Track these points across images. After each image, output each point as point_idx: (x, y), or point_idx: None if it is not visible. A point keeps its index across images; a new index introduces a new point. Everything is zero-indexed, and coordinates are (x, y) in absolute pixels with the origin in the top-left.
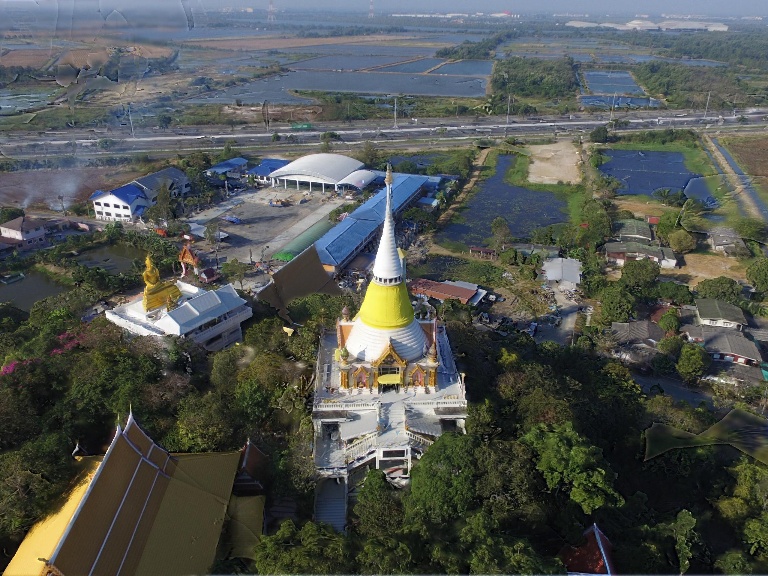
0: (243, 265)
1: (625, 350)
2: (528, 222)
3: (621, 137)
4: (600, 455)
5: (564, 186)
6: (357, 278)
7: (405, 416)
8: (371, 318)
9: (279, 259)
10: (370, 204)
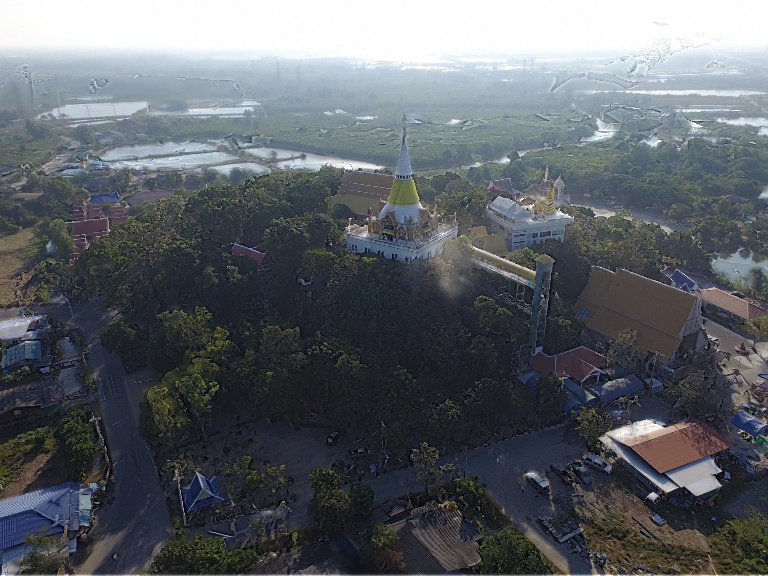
0: (766, 324)
1: (420, 508)
2: None
3: None
4: (274, 237)
5: None
6: None
7: None
8: None
9: None
10: None
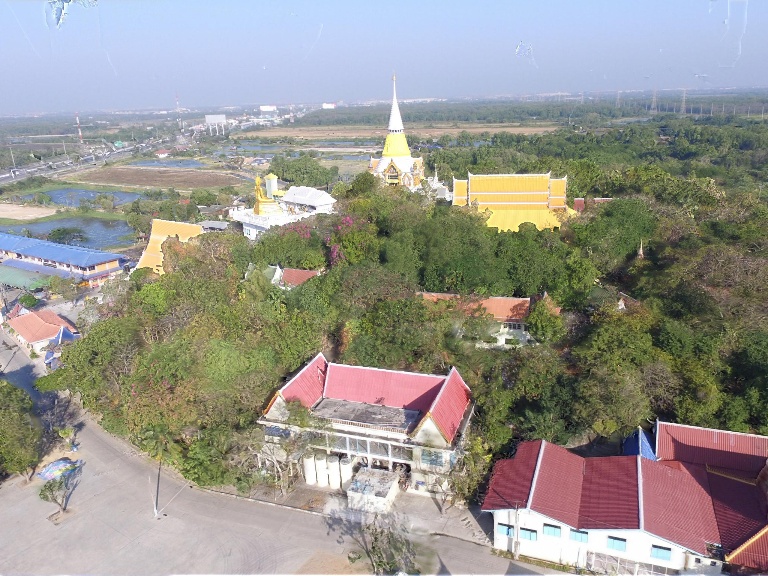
0: None
1: None
2: (111, 228)
3: (1, 189)
4: None
5: (65, 213)
6: (128, 269)
7: (442, 185)
8: (405, 151)
9: (39, 287)
10: (4, 241)
